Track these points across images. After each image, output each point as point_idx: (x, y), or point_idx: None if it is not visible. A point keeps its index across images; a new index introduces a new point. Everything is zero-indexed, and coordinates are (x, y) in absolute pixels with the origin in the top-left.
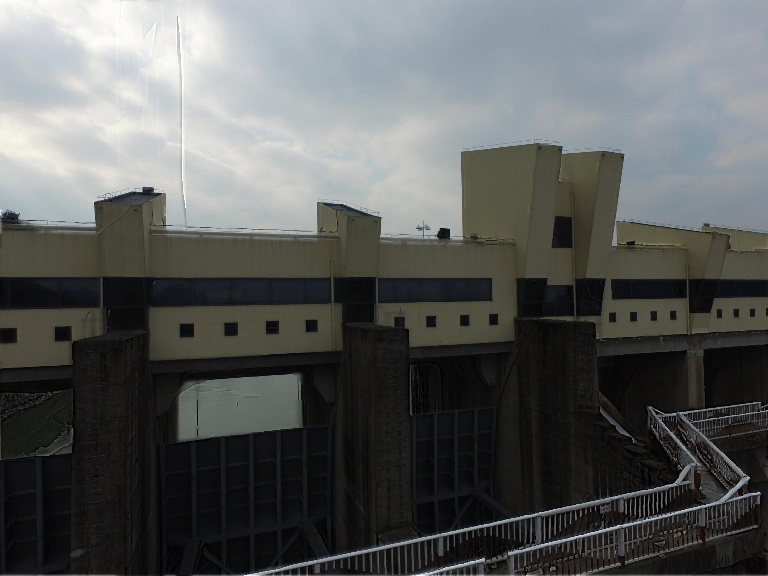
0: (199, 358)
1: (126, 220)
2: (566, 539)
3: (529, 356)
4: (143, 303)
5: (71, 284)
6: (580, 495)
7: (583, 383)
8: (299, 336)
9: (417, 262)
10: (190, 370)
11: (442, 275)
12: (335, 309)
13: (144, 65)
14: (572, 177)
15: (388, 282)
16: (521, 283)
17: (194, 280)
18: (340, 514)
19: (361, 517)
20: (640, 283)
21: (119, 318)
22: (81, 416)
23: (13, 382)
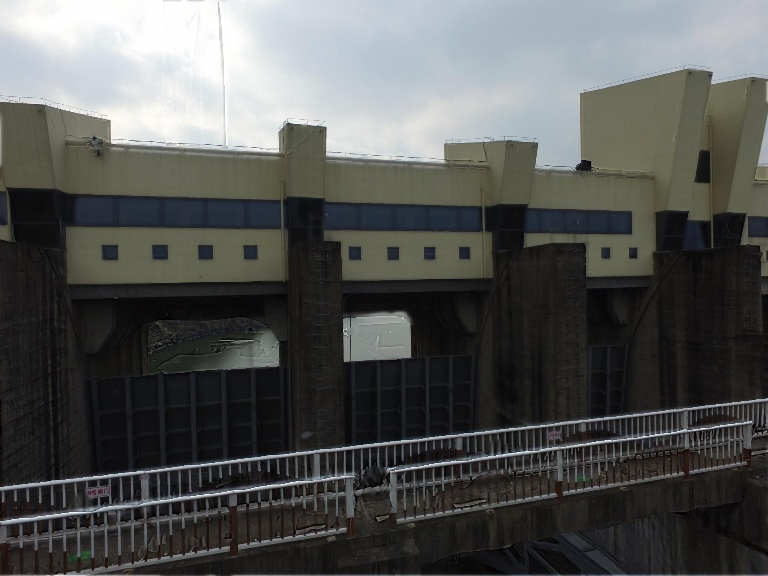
0: (365, 280)
1: (311, 141)
2: None
3: (674, 288)
4: (321, 224)
5: (255, 206)
6: None
7: (747, 306)
8: (453, 262)
9: (560, 193)
10: (357, 291)
11: (584, 207)
12: (486, 237)
13: None
14: (710, 109)
15: (533, 213)
16: (662, 216)
17: (360, 205)
18: None
19: None
20: None
21: (299, 238)
22: (306, 310)
23: (209, 296)
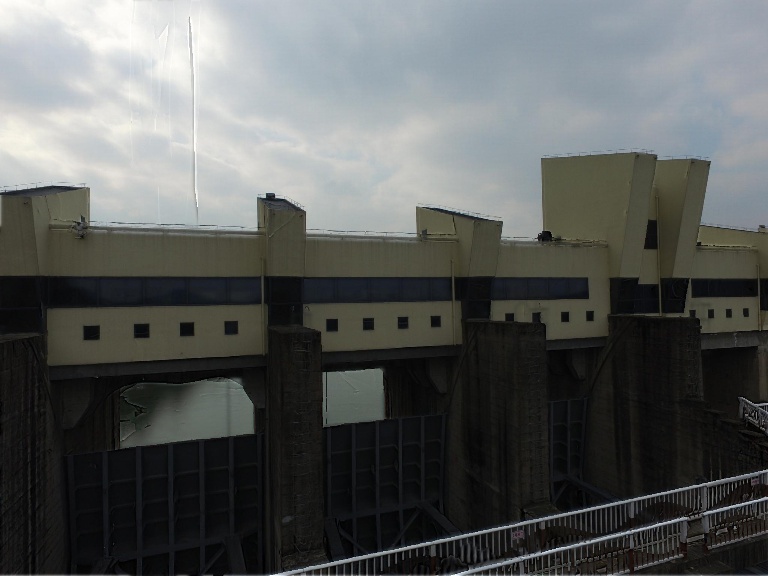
0: (342, 350)
1: (292, 225)
2: (745, 503)
3: (626, 350)
4: (300, 300)
5: (237, 283)
6: (687, 477)
7: (690, 374)
8: (425, 331)
9: (524, 263)
10: (334, 361)
11: (545, 275)
12: (455, 306)
13: (157, 67)
14: (657, 182)
15: (499, 281)
16: (615, 282)
17: (337, 279)
18: (456, 496)
19: (494, 495)
20: (716, 282)
21: (278, 314)
22: (288, 399)
23: (190, 371)
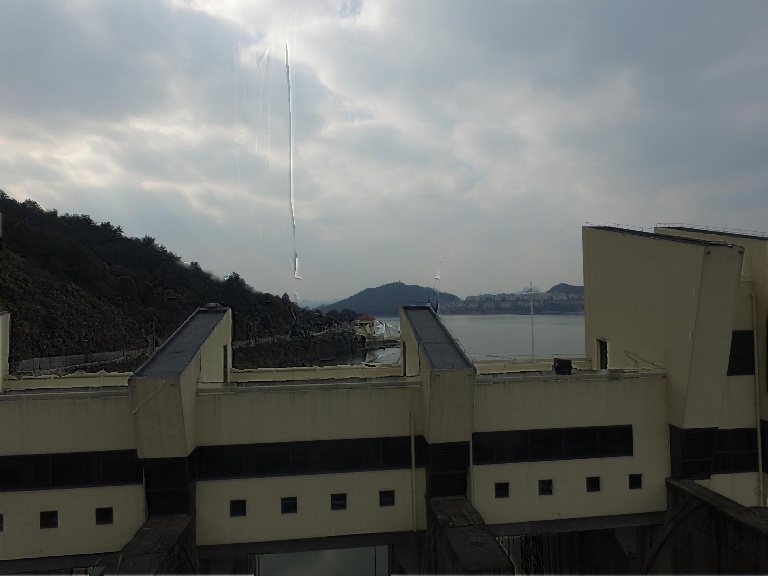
0: (252, 541)
1: (162, 396)
2: None
3: (692, 545)
4: (186, 484)
5: (113, 458)
6: None
7: None
8: (371, 512)
9: (525, 408)
10: None
11: (560, 424)
12: (416, 476)
13: (258, 91)
14: (753, 273)
15: (486, 436)
16: (677, 433)
17: (246, 446)
18: None
19: None
20: None
21: (162, 499)
22: None
23: None
